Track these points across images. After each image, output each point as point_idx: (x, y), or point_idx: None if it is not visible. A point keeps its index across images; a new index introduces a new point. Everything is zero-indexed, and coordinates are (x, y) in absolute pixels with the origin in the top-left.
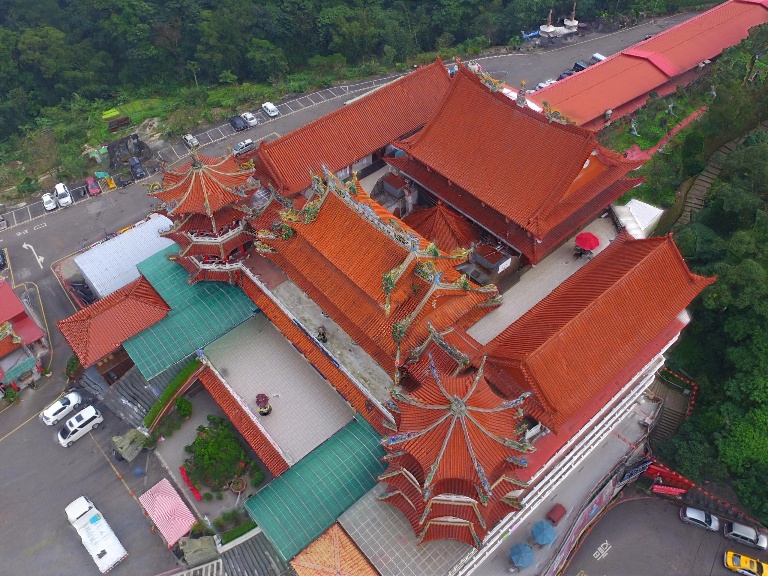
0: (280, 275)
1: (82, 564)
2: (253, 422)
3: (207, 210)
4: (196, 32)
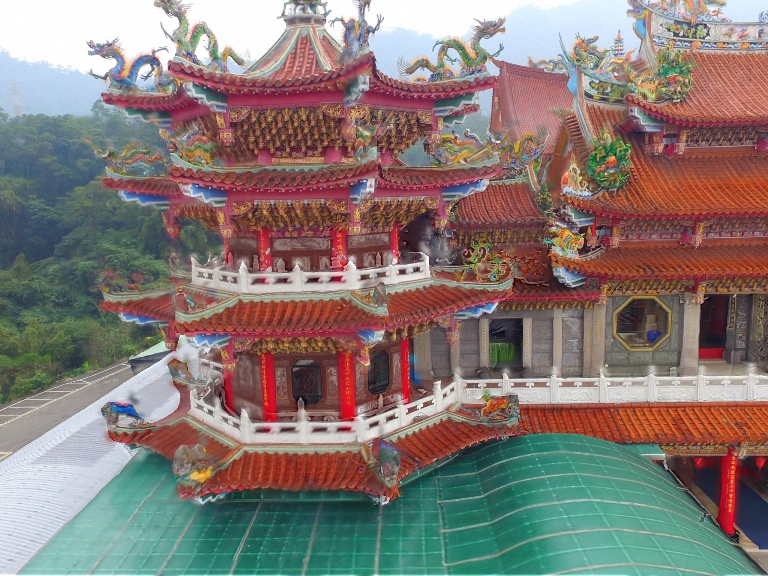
0: None
1: None
2: None
3: (483, 54)
4: None
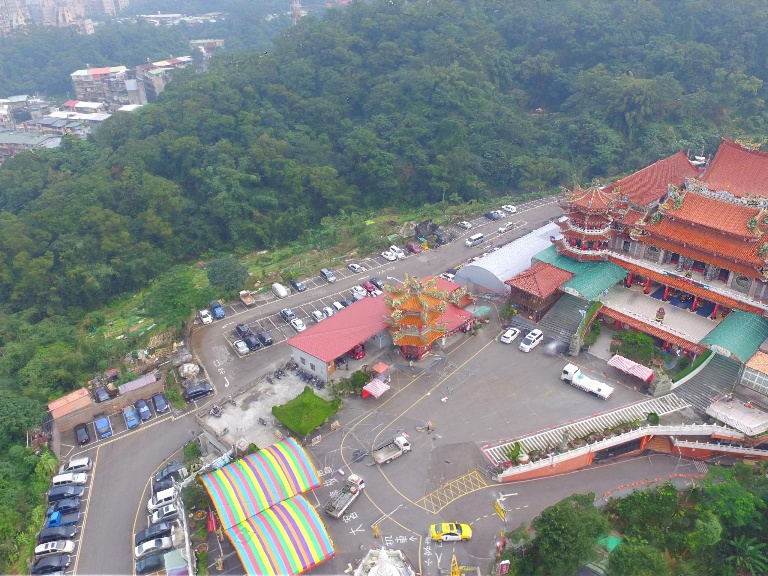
0: (633, 257)
1: (585, 399)
2: (656, 327)
3: None
4: (425, 171)
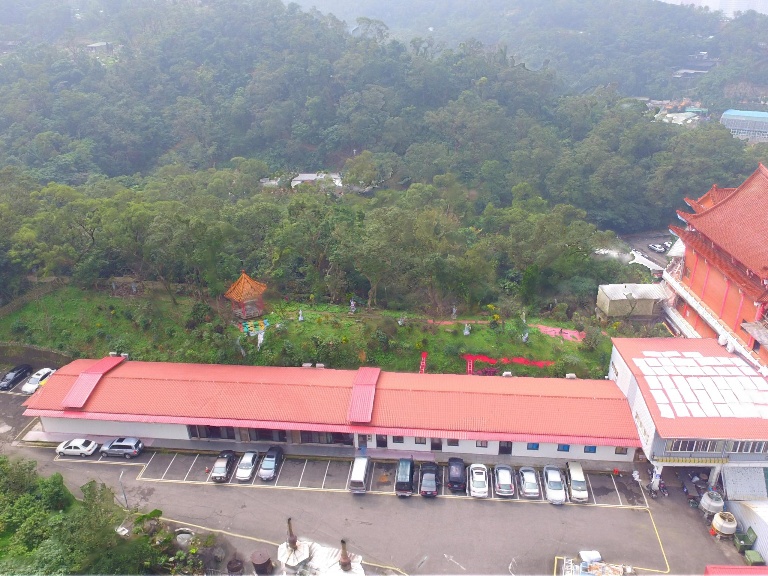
0: None
1: None
2: None
3: None
4: None
